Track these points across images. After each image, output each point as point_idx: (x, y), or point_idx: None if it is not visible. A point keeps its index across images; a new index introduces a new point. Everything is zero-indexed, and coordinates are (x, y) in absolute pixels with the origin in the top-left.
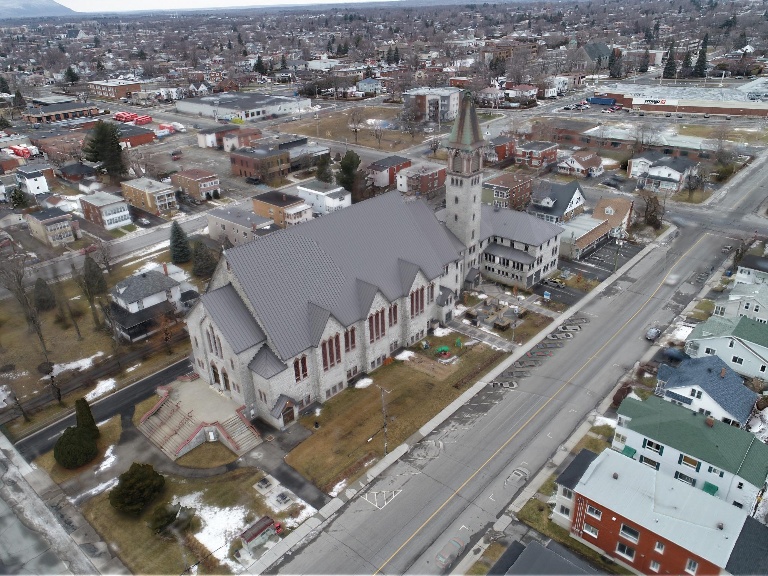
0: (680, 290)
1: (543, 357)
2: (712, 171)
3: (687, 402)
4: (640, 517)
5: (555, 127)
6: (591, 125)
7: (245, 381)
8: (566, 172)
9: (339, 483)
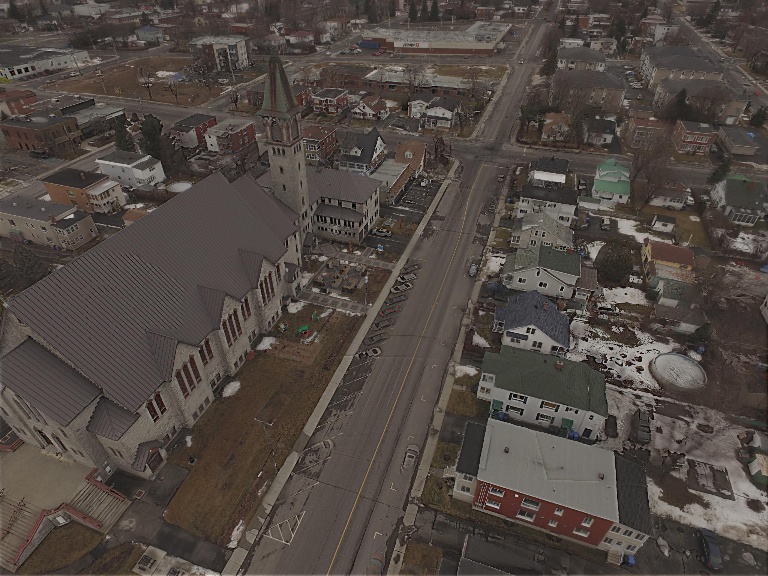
0: (480, 222)
1: (394, 314)
2: None
3: (524, 339)
4: (540, 491)
5: (341, 73)
6: (369, 70)
7: (88, 445)
8: (360, 117)
9: (236, 528)
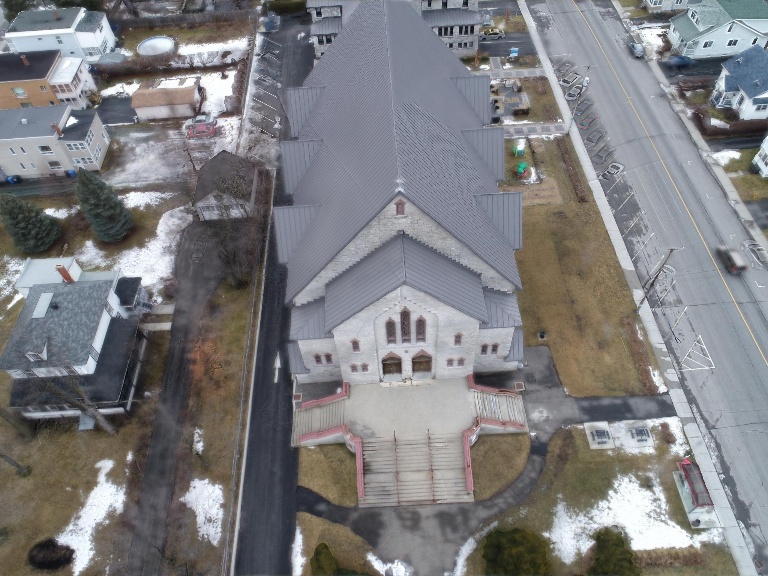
0: None
1: (596, 123)
2: None
3: None
4: None
5: None
6: None
7: None
8: None
9: (652, 375)
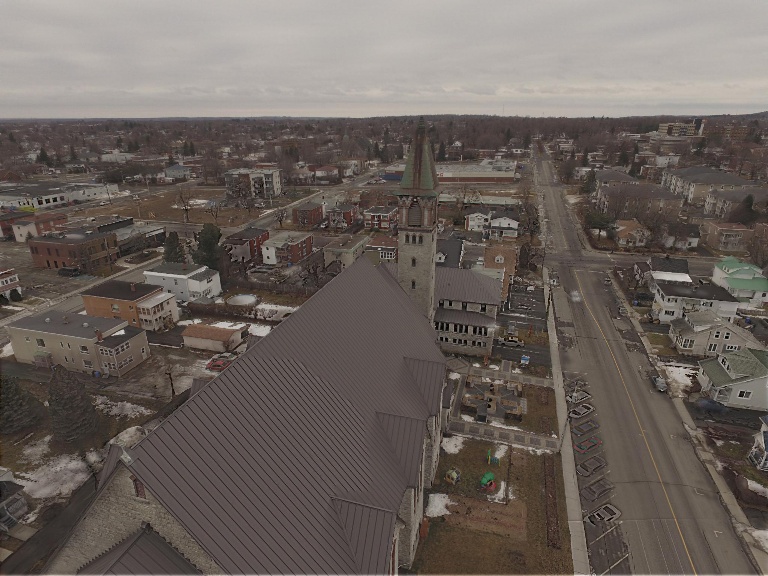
0: (618, 327)
1: (597, 449)
2: (522, 221)
3: None
4: None
5: (384, 194)
6: None
7: None
8: None
9: None
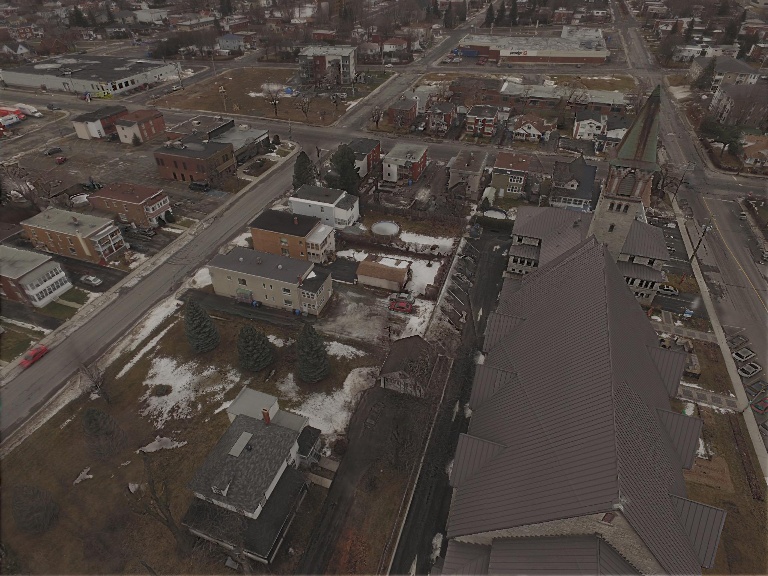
0: (764, 274)
1: None
2: None
3: None
4: None
5: None
6: (501, 83)
7: None
8: (522, 138)
9: None
